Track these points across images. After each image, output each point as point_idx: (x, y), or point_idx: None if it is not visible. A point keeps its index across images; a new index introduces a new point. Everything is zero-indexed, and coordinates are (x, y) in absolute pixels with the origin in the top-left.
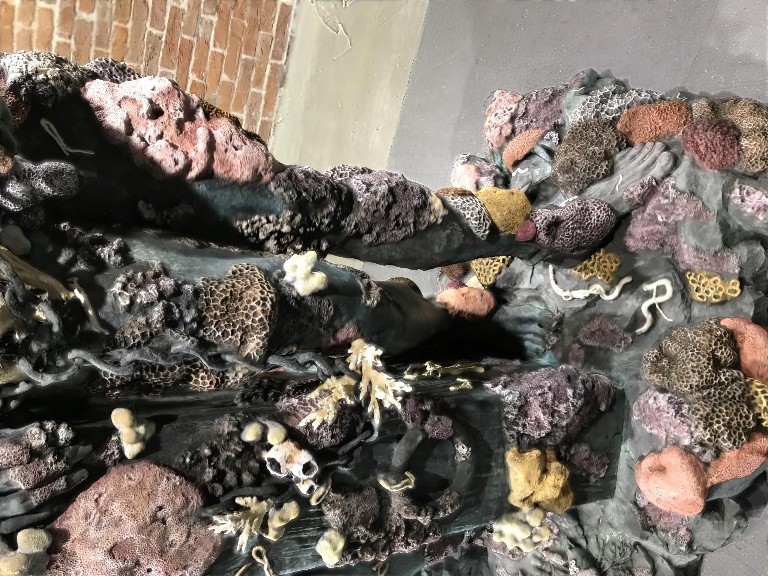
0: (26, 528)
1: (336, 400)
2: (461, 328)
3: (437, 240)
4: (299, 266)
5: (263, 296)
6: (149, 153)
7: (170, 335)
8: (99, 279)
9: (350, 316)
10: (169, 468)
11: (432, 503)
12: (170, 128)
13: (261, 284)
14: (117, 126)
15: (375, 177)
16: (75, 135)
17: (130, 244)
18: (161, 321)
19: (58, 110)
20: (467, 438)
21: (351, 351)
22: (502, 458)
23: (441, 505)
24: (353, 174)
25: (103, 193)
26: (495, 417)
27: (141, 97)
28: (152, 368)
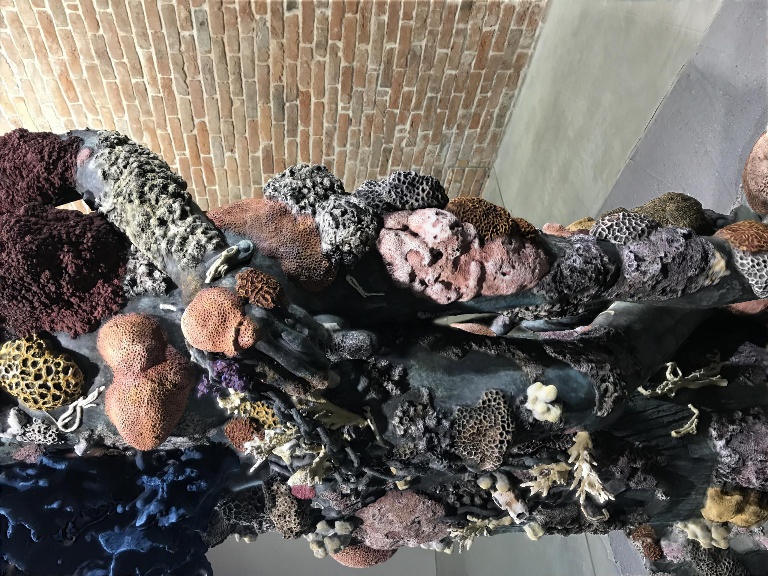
0: (339, 521)
1: (551, 483)
2: (726, 313)
3: (707, 298)
4: (539, 398)
5: (502, 439)
6: (428, 293)
7: (430, 457)
8: (384, 408)
9: (579, 423)
10: (425, 495)
11: (624, 518)
12: (447, 269)
13: (502, 424)
14: (403, 279)
15: (651, 251)
16: (371, 284)
17: (408, 366)
18: (424, 449)
19: (359, 268)
20: (669, 489)
21: (575, 440)
22: (704, 490)
23: (631, 522)
24: (629, 239)
25: (391, 312)
26: (707, 467)
27: (424, 250)
28: (417, 464)
